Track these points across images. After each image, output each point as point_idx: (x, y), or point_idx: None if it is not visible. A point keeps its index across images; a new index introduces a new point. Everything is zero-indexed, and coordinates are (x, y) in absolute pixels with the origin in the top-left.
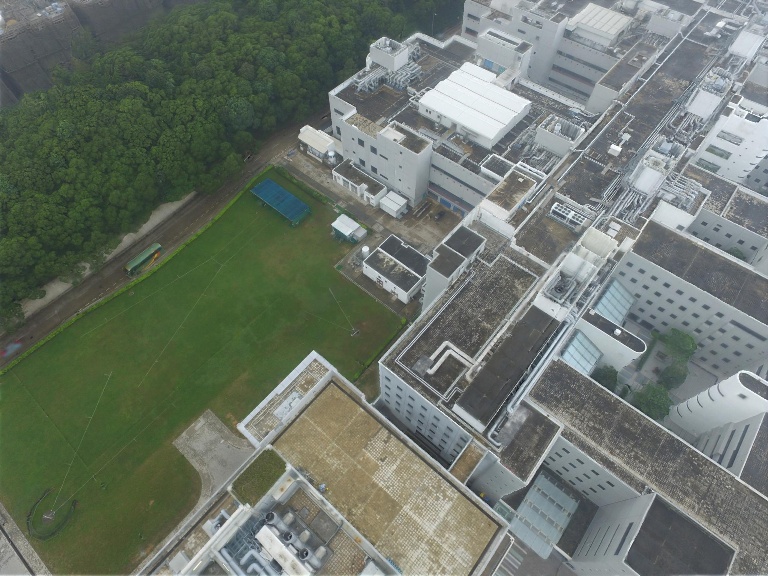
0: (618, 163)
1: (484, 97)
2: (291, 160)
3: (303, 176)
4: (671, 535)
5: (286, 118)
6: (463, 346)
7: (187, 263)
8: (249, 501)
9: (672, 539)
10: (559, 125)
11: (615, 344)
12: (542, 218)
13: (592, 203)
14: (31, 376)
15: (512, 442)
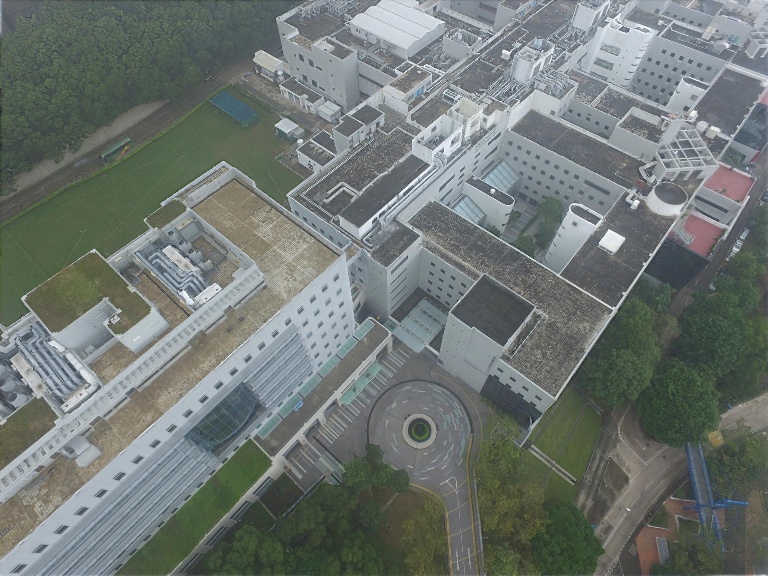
0: (508, 65)
1: (406, 19)
2: (247, 80)
3: (256, 92)
4: (491, 300)
5: (244, 45)
6: (356, 186)
7: (152, 154)
8: (158, 226)
9: (492, 303)
10: (460, 35)
11: (491, 201)
12: (436, 103)
13: (479, 92)
14: (20, 232)
15: (382, 245)
